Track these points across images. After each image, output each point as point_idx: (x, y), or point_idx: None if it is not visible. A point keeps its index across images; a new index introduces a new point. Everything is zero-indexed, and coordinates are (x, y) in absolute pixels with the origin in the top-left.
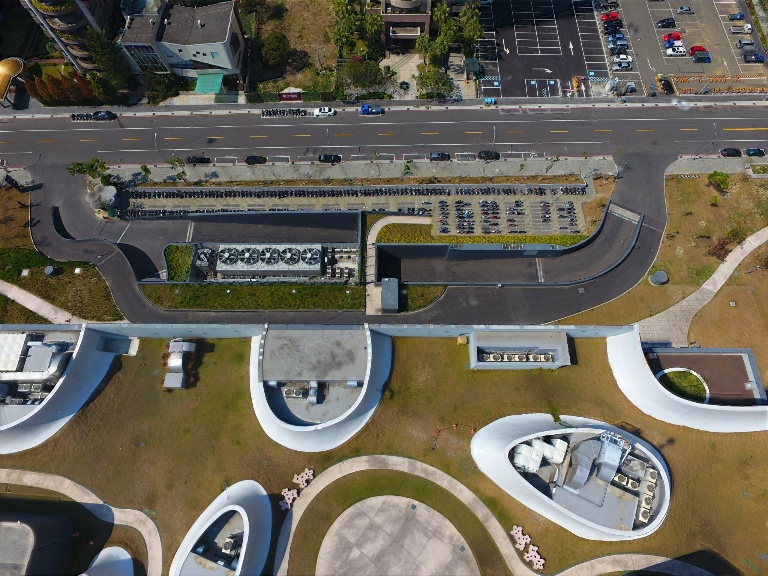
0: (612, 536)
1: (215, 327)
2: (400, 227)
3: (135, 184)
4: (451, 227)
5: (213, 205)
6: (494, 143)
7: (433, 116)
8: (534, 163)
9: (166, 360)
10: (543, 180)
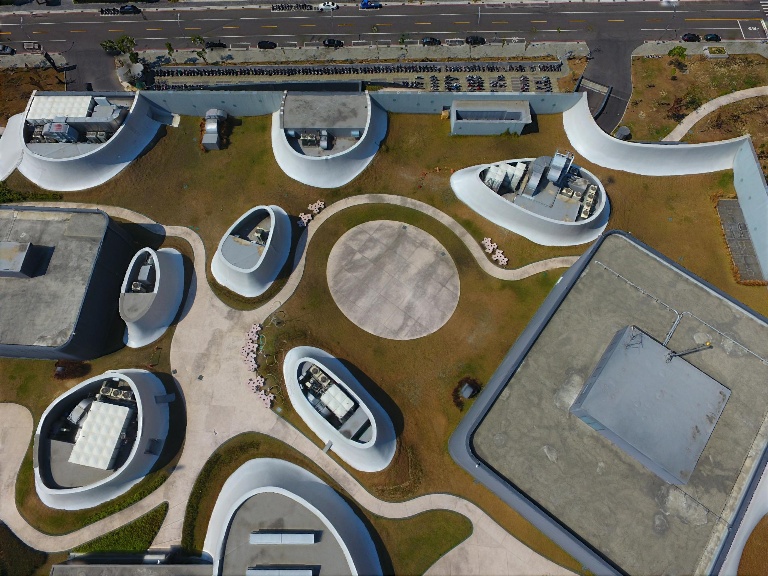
0: (562, 241)
1: (244, 93)
2: None
3: (159, 65)
4: None
5: (229, 81)
6: (480, 31)
7: (426, 10)
8: (515, 47)
9: (203, 128)
10: (523, 59)
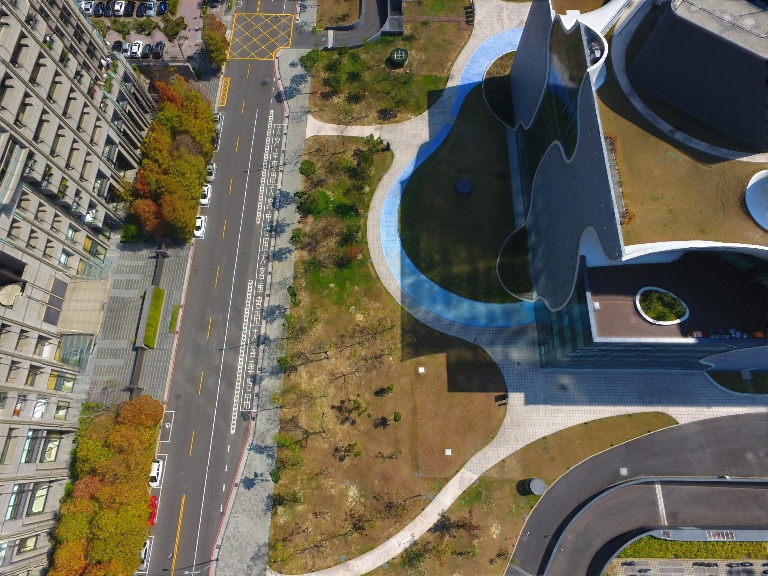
0: None
1: None
2: None
3: None
4: None
5: None
6: None
7: None
8: None
9: None
10: None
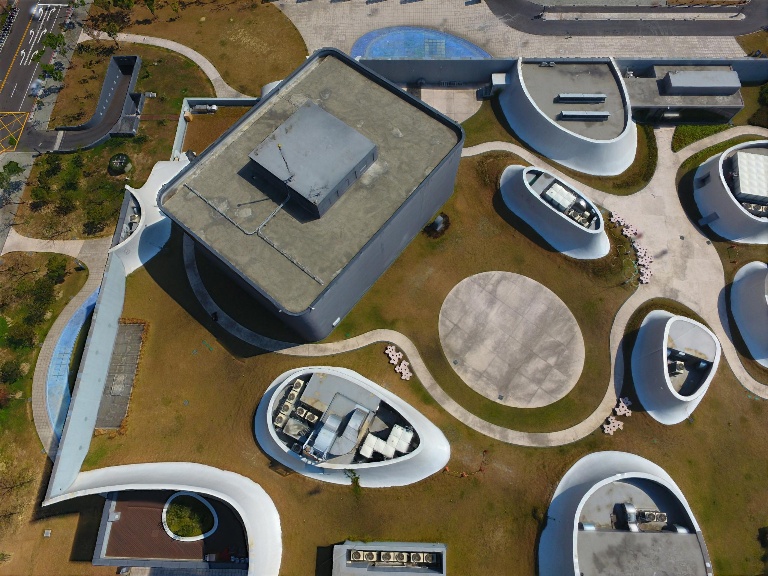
0: None
1: None
2: None
3: None
4: None
5: None
6: None
7: None
8: None
9: None
10: None
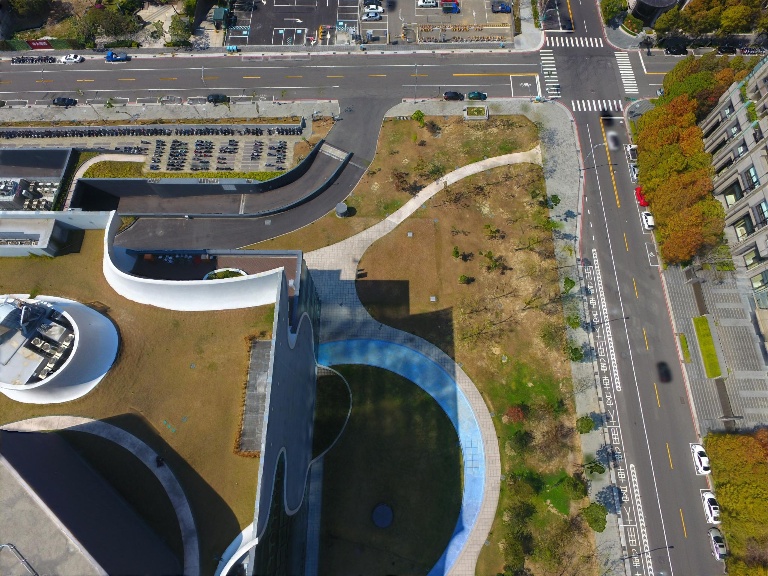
0: (41, 398)
1: None
2: (111, 164)
3: None
4: (163, 165)
5: None
6: (227, 88)
7: (176, 63)
8: (260, 106)
9: None
10: (262, 121)
